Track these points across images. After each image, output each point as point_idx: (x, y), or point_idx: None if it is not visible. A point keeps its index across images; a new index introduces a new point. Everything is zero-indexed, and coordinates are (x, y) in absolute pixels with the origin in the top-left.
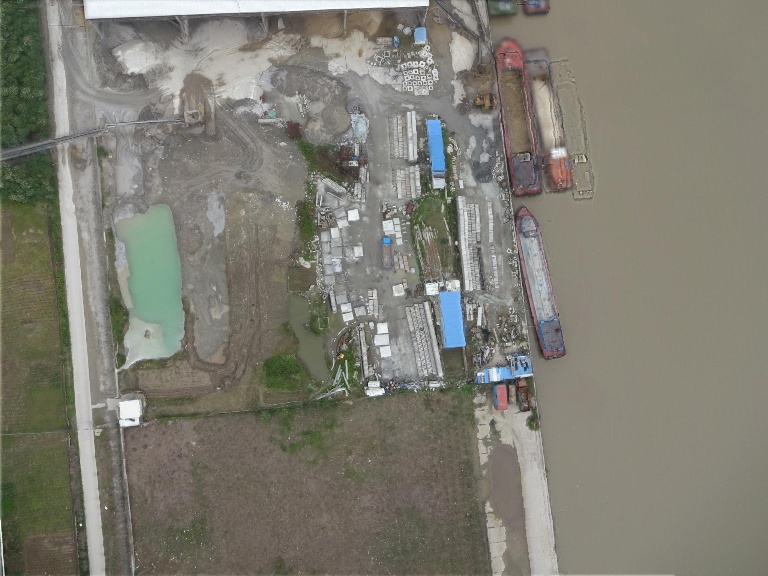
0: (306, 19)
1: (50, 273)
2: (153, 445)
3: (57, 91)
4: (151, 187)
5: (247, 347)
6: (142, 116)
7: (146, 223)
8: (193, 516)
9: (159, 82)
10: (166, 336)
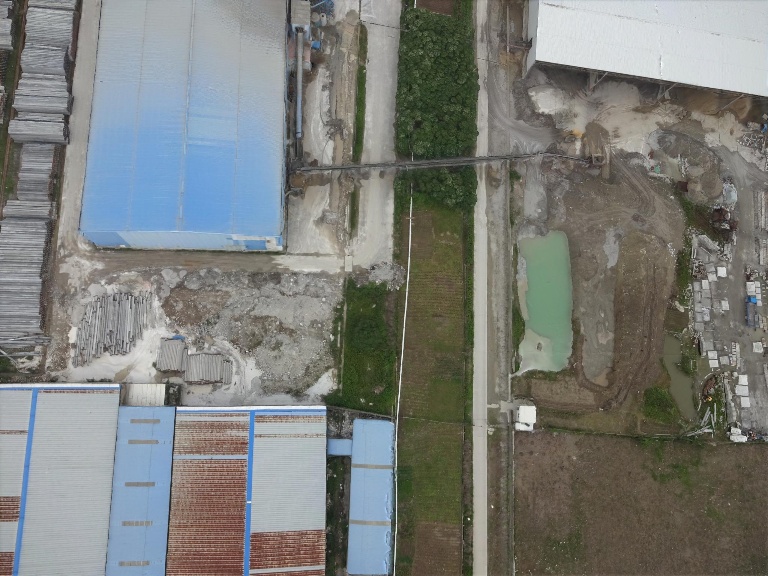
0: (693, 95)
1: (461, 274)
2: (538, 453)
3: (480, 115)
4: (556, 214)
5: (633, 375)
6: (550, 150)
7: (545, 245)
8: (570, 529)
9: (565, 124)
10: (555, 351)
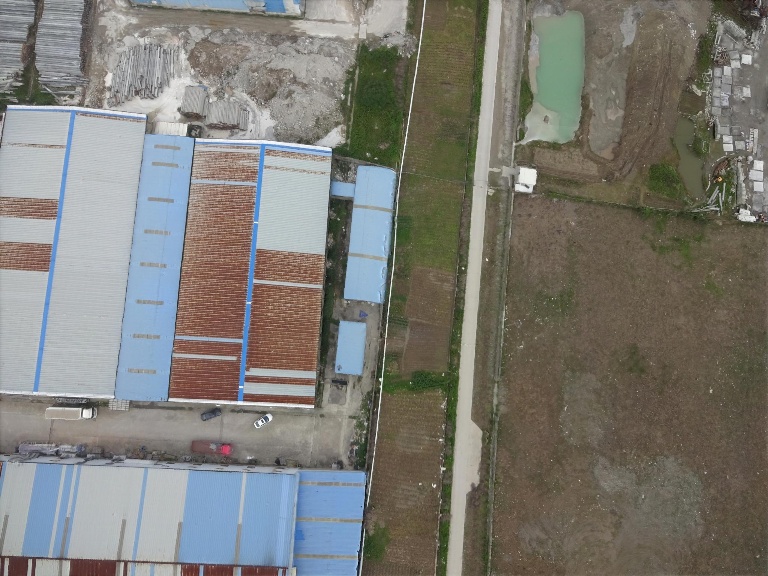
0: None
1: (472, 47)
2: (537, 216)
3: None
4: None
5: (639, 148)
6: None
7: (560, 24)
8: (562, 287)
9: None
10: (562, 125)
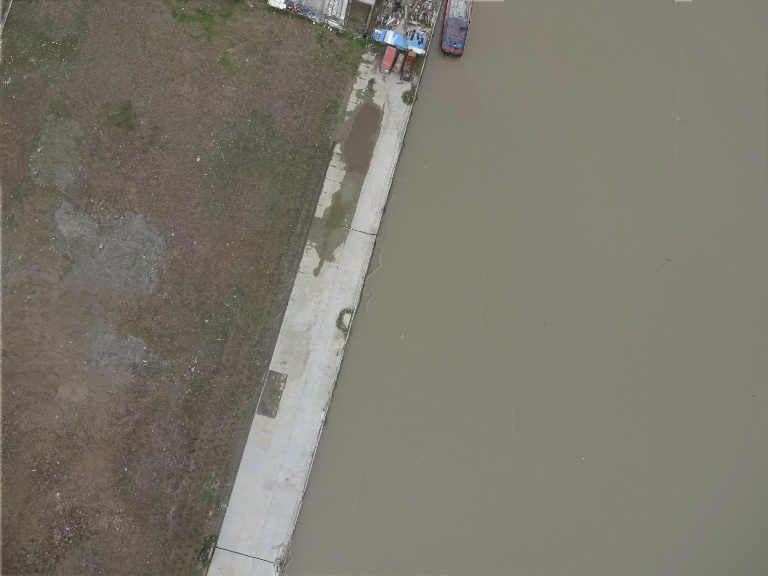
0: None
1: None
2: None
3: None
4: None
5: None
6: None
7: None
8: (67, 34)
9: None
10: None
